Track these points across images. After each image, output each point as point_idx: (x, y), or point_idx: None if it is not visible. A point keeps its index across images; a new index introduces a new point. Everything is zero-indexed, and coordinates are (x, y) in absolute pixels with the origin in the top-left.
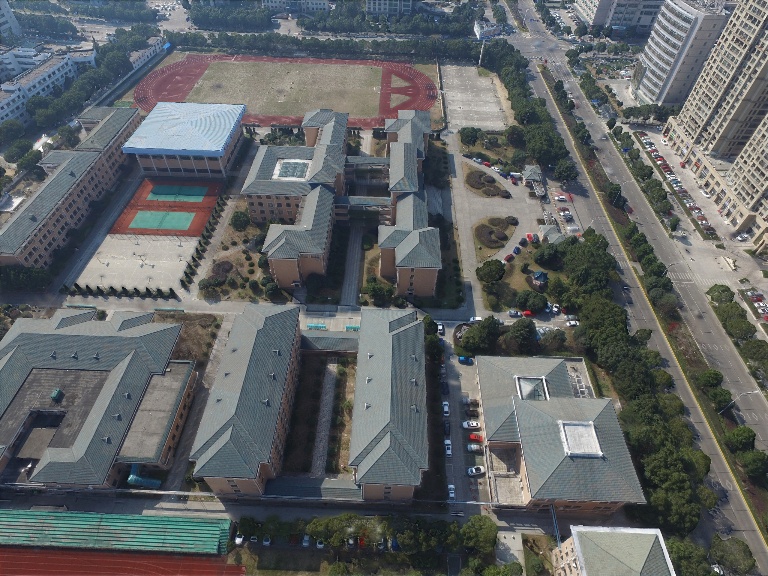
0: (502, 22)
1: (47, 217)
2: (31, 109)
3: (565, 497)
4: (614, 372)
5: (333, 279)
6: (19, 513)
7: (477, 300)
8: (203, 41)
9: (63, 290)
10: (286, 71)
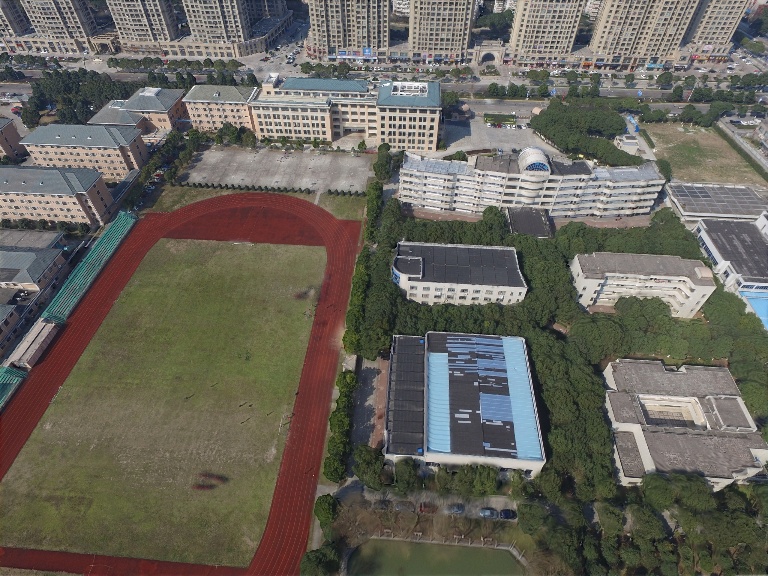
0: None
1: None
2: None
3: (172, 104)
4: (129, 95)
5: None
6: (54, 301)
7: None
8: None
9: None
10: None
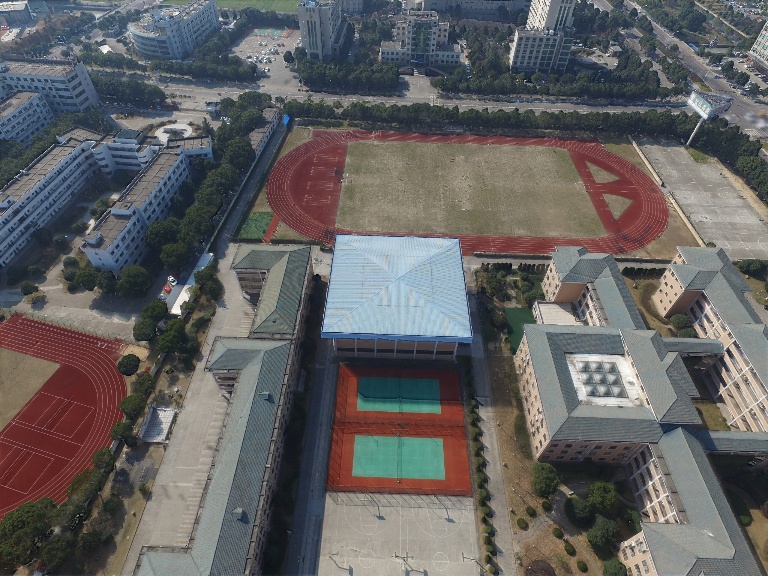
0: (682, 80)
1: (260, 506)
2: (154, 243)
3: None
4: None
5: None
6: None
7: None
8: (331, 113)
9: None
10: (449, 157)
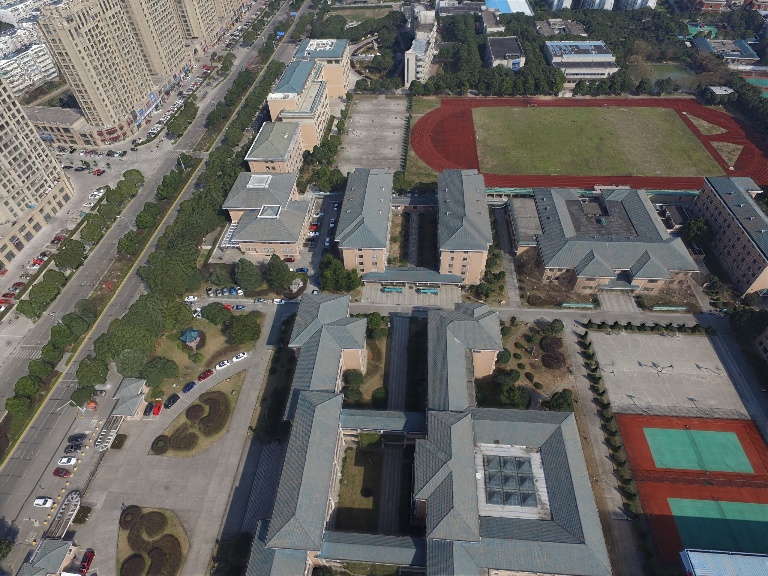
0: None
1: None
2: None
3: None
4: None
5: (419, 340)
6: None
7: (269, 323)
8: None
9: (711, 330)
10: None
